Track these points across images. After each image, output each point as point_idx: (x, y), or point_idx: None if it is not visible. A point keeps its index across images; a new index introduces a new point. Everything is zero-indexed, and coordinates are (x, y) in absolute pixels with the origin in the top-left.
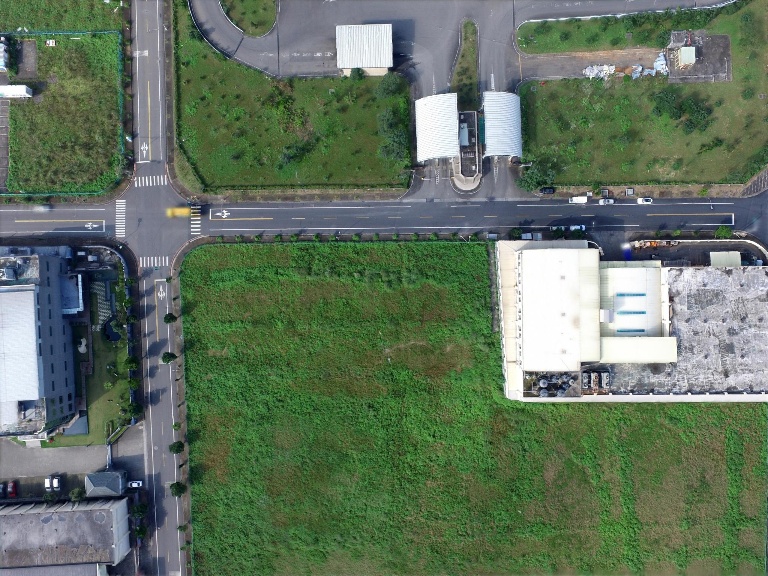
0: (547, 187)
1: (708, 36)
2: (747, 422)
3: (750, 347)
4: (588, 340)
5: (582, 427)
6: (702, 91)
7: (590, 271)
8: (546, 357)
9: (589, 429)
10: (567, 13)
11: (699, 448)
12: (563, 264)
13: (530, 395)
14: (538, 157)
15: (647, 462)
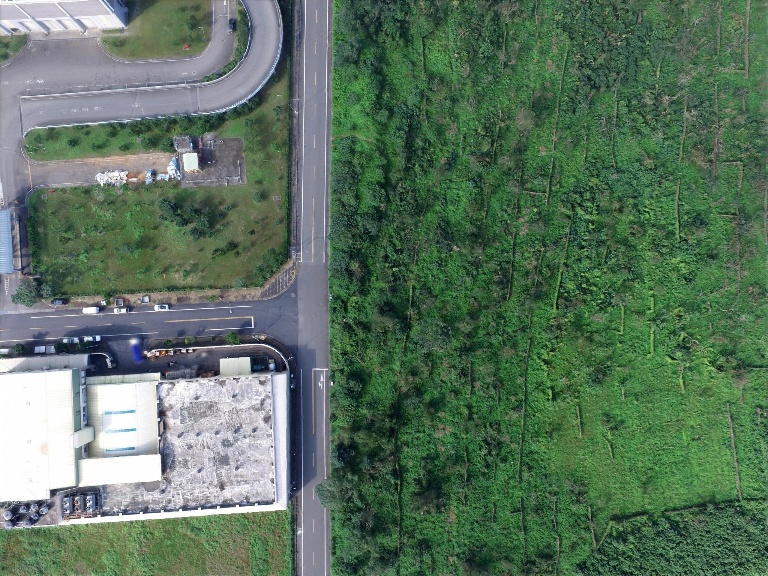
0: (58, 298)
1: (221, 139)
2: (271, 527)
3: (245, 458)
4: (59, 466)
5: (103, 544)
6: (217, 195)
7: (60, 394)
8: (13, 487)
9: (110, 545)
10: (75, 119)
11: (223, 557)
12: (28, 389)
13: (3, 526)
14: (50, 267)
15: (171, 575)
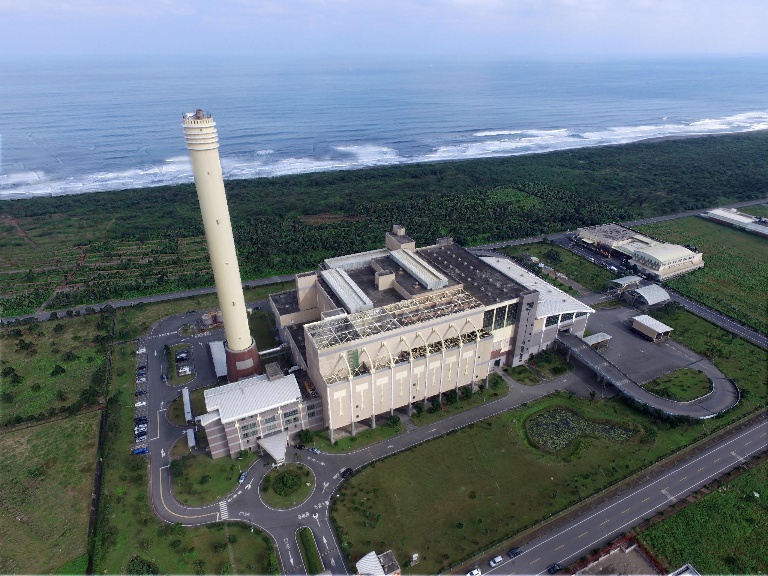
0: None
1: None
2: None
3: None
4: None
5: None
6: None
7: None
8: (685, 250)
9: None
10: None
11: None
12: None
13: None
14: None
15: None
